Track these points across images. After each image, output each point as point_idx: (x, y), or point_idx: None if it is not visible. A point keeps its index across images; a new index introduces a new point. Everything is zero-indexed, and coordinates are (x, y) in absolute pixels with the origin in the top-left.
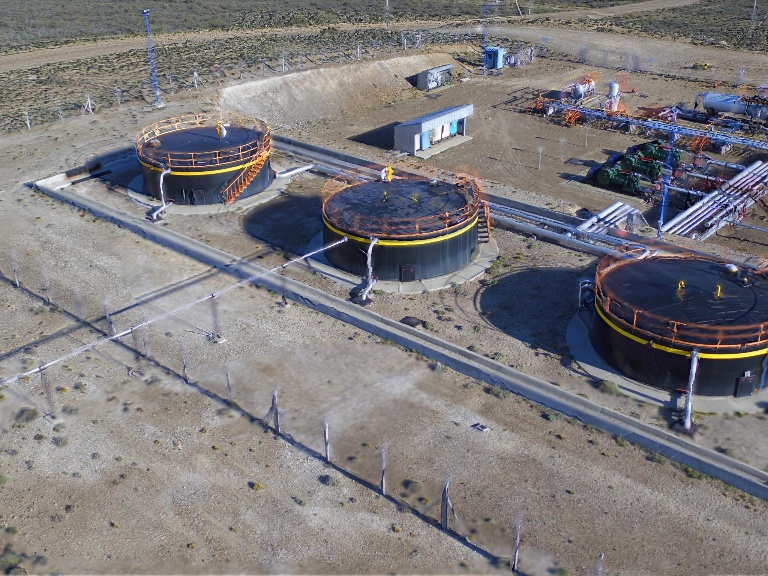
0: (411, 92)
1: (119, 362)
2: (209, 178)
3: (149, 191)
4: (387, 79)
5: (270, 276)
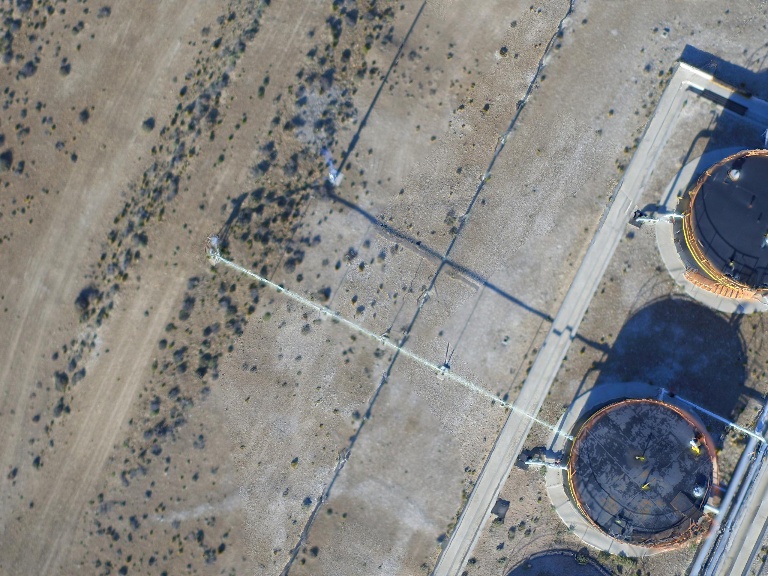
0: None
1: (395, 320)
2: None
3: None
4: None
5: (551, 371)
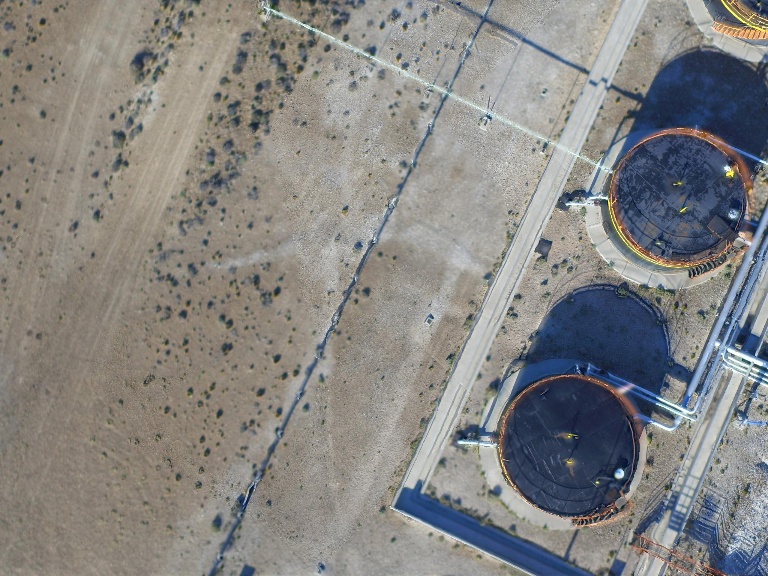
0: None
1: (438, 75)
2: (720, 1)
3: None
4: None
5: (588, 120)
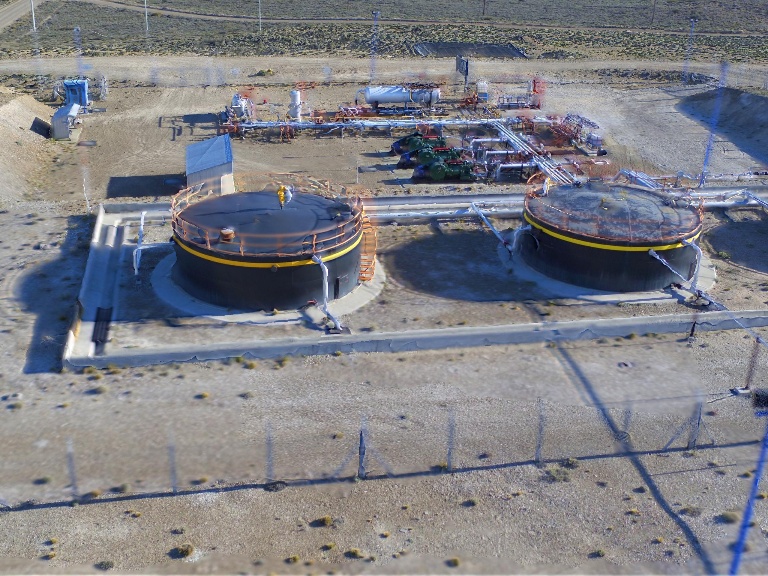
0: (55, 144)
1: None
2: (351, 255)
3: (252, 305)
4: (19, 134)
5: (602, 325)
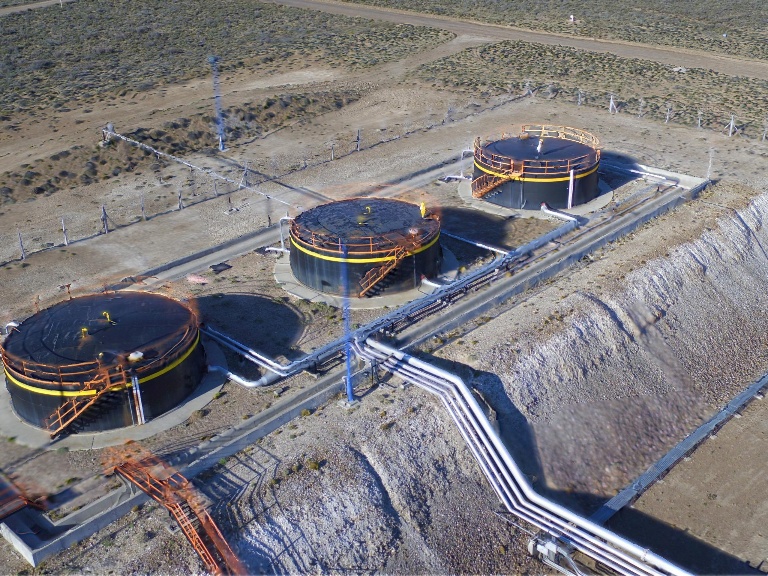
0: None
1: None
2: None
3: None
4: None
5: None
